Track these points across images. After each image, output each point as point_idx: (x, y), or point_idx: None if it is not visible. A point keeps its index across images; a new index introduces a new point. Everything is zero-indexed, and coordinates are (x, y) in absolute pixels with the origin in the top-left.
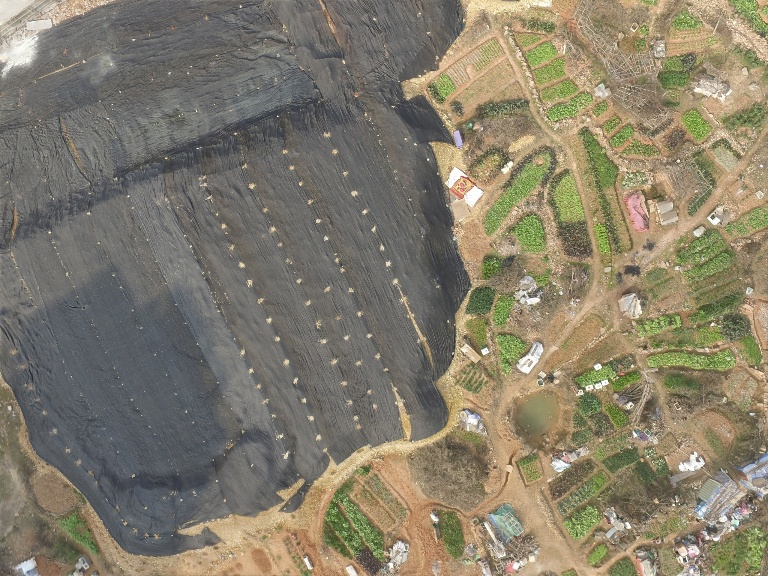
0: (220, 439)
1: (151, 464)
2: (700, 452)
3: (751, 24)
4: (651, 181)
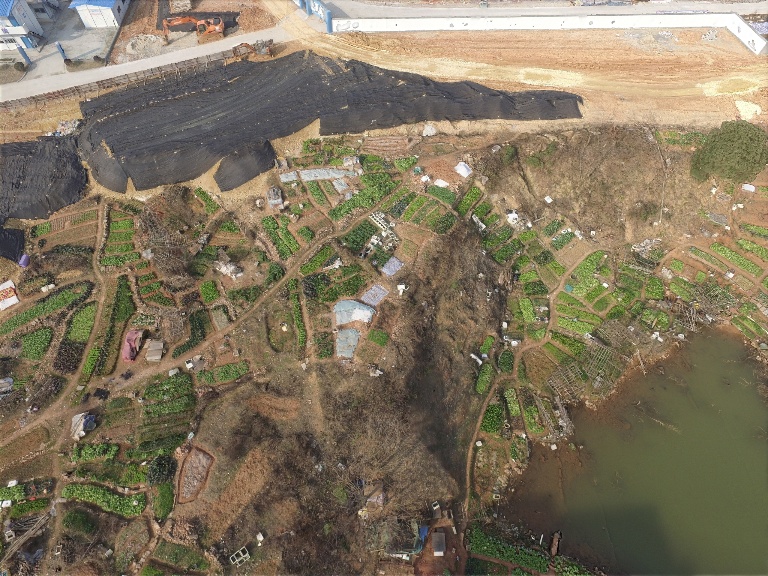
0: None
1: None
2: None
3: (270, 236)
4: (157, 324)
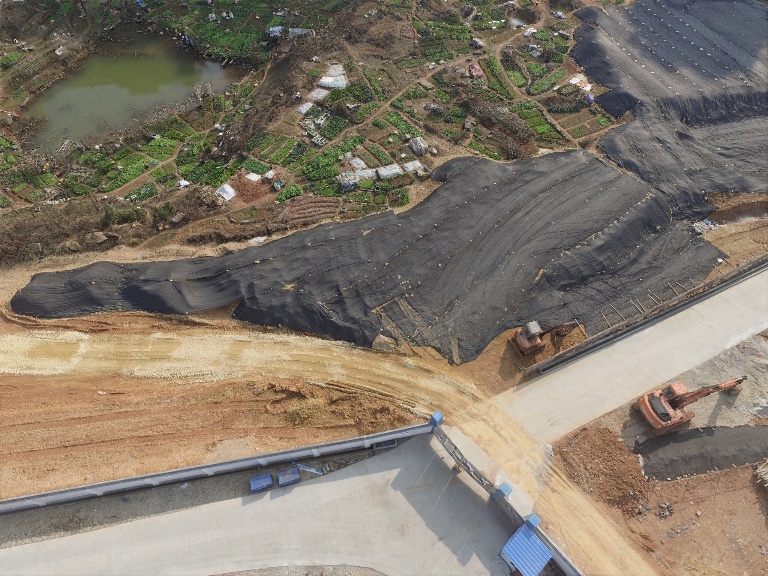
0: (694, 9)
1: (728, 5)
2: (444, 0)
3: None
4: None
